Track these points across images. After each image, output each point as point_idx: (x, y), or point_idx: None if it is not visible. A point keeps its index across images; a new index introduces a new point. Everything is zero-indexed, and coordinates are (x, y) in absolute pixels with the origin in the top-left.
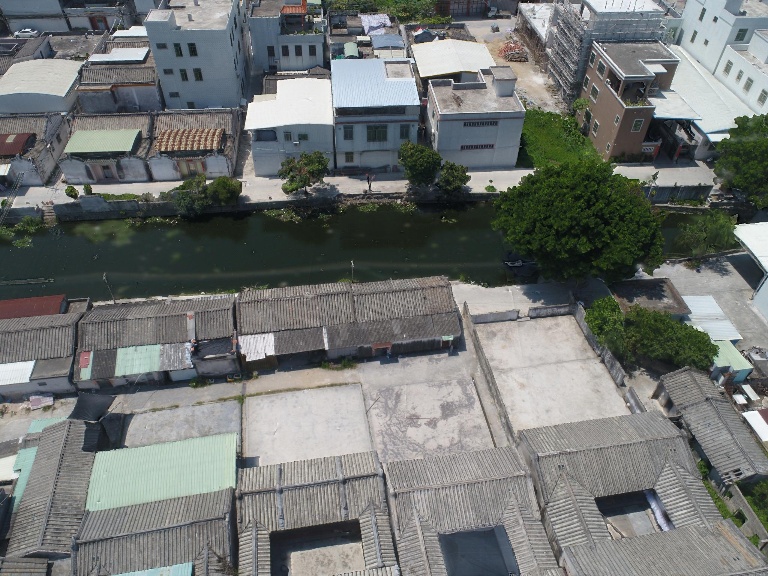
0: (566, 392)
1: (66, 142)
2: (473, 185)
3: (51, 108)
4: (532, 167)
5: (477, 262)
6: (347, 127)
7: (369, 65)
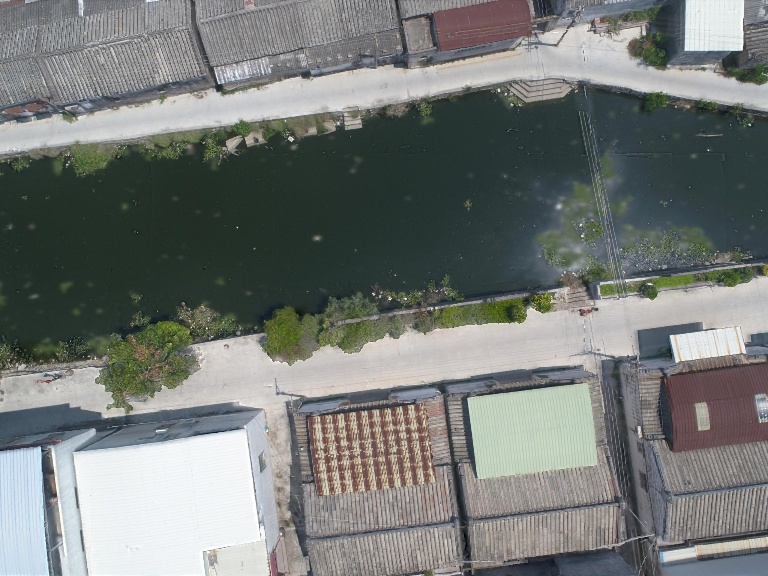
0: None
1: (639, 497)
2: None
3: (696, 567)
4: None
5: None
6: (43, 441)
7: None
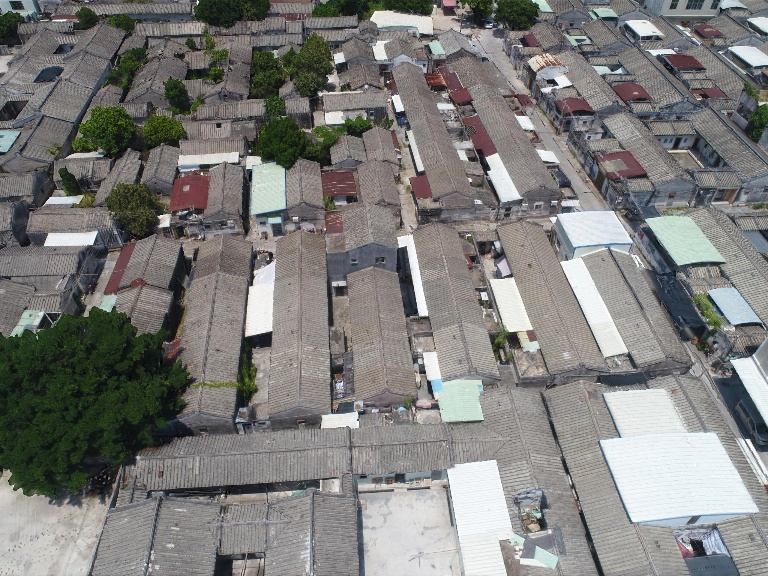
0: (0, 66)
1: None
2: None
3: None
4: None
5: None
6: None
7: None
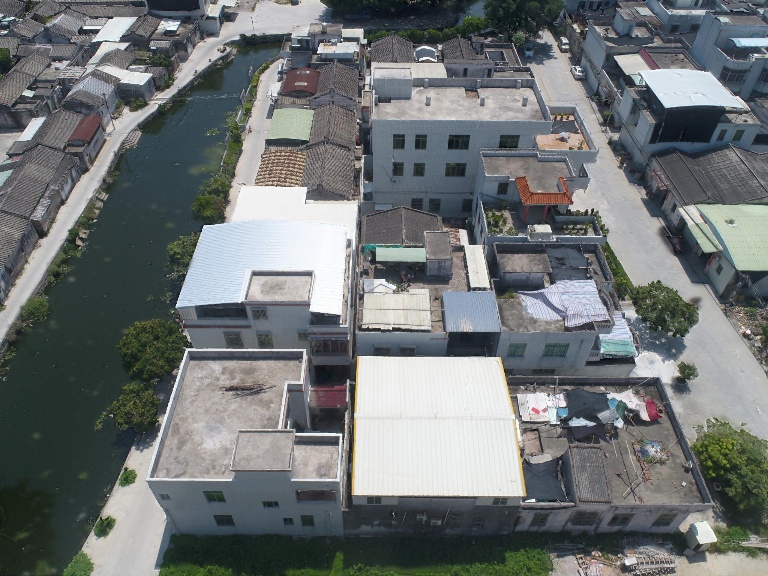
0: None
1: None
2: (149, 454)
3: None
4: (162, 565)
5: (7, 442)
6: None
7: (311, 258)
